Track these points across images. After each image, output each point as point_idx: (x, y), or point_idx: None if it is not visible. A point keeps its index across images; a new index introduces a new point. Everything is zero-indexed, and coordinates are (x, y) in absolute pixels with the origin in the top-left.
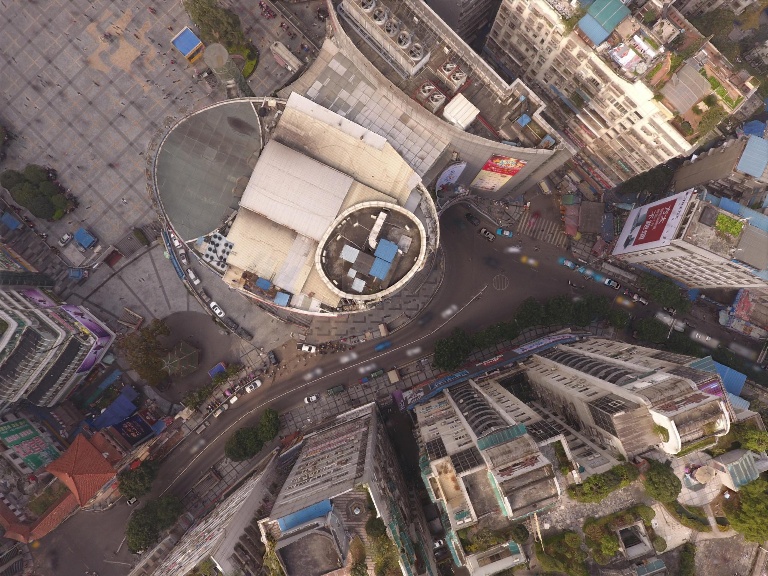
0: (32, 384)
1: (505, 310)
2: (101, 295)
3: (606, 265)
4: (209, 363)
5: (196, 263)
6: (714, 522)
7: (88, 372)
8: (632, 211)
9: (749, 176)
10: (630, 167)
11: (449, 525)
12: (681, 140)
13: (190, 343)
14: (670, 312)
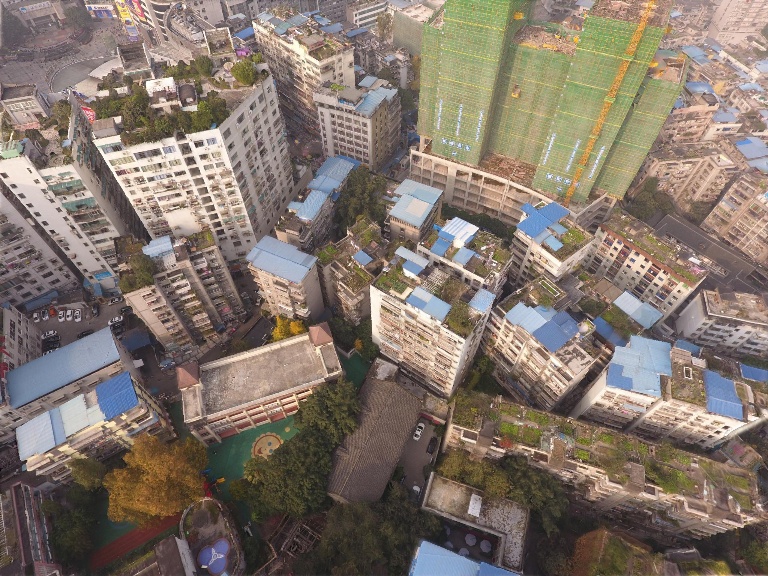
0: None
1: None
2: None
3: None
4: None
5: None
6: None
7: None
8: None
9: None
10: None
11: None
12: (315, 60)
13: None
14: None
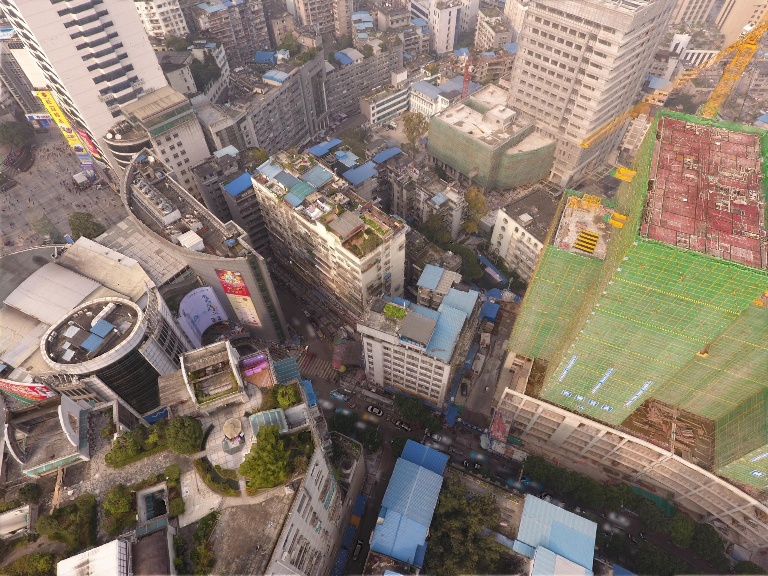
0: None
1: None
2: None
3: (365, 391)
4: None
5: None
6: (244, 486)
7: None
8: None
9: (432, 292)
10: (355, 297)
11: None
12: (353, 257)
13: None
14: (434, 438)
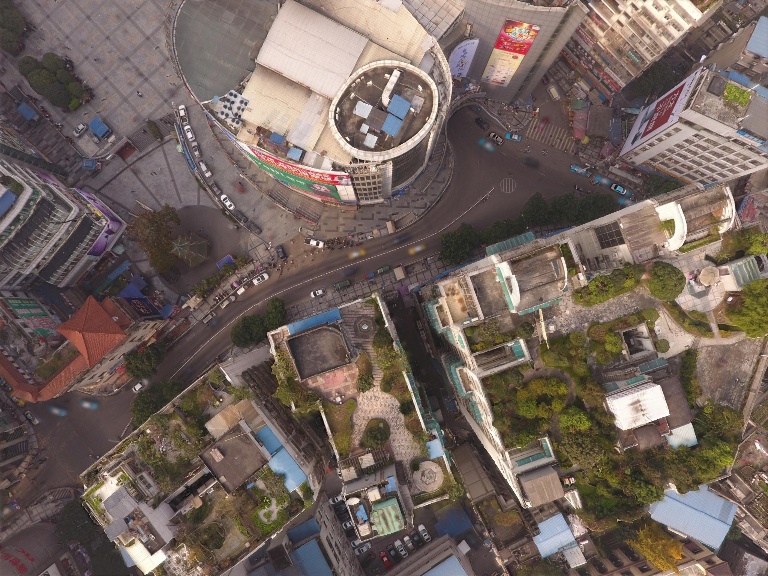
0: (44, 260)
1: (512, 212)
2: (113, 188)
3: (613, 168)
4: (218, 257)
5: (208, 156)
6: (716, 329)
7: (98, 259)
8: (640, 113)
9: (758, 59)
10: (640, 56)
11: (454, 362)
12: (692, 8)
13: (199, 236)
14: None
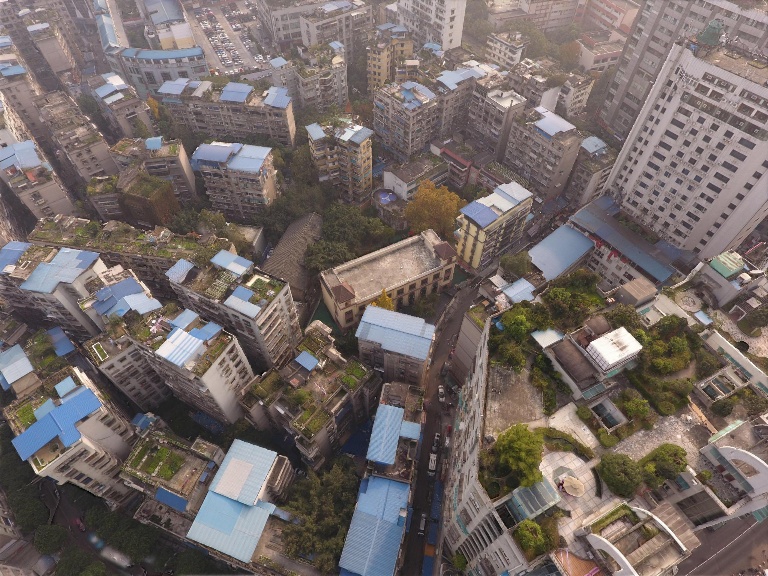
0: None
1: None
2: None
3: None
4: None
5: None
6: None
7: None
8: None
9: None
10: None
11: None
12: None
13: None
14: None
